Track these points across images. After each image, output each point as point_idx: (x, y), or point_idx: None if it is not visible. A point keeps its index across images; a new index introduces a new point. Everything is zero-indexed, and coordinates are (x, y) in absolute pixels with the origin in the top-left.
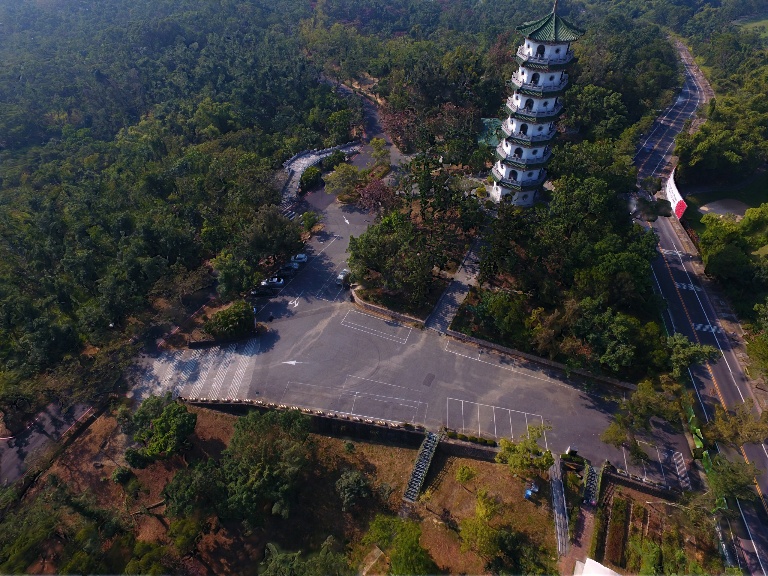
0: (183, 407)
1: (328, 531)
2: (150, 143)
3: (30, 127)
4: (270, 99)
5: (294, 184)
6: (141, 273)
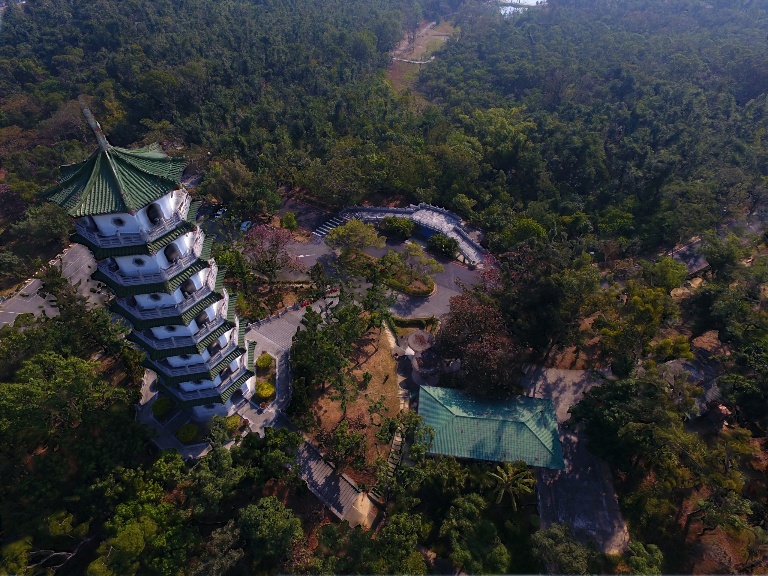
0: None
1: None
2: (464, 124)
3: (526, 81)
4: (600, 176)
5: None
6: (238, 146)
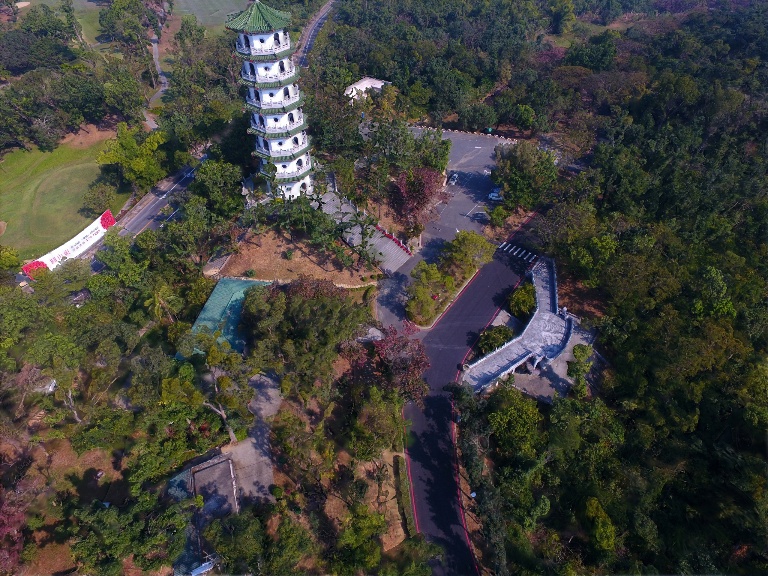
0: (523, 115)
1: (446, 127)
2: None
3: None
4: None
5: (542, 290)
6: None
